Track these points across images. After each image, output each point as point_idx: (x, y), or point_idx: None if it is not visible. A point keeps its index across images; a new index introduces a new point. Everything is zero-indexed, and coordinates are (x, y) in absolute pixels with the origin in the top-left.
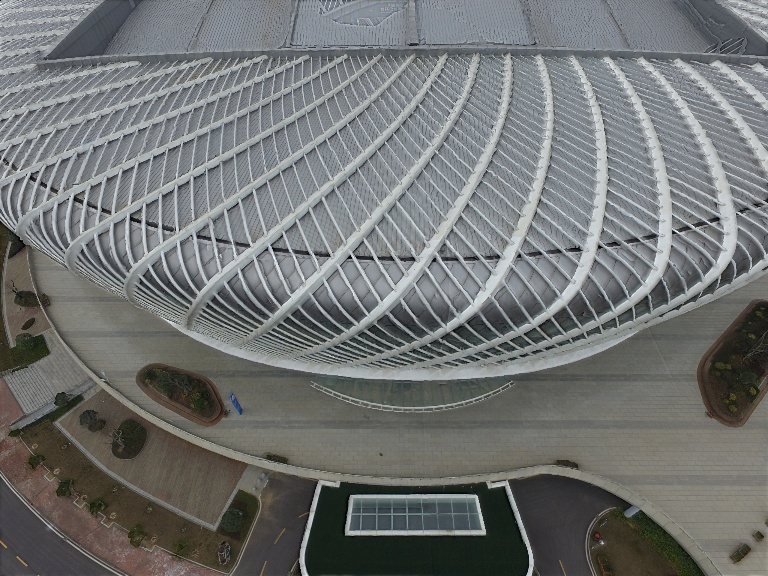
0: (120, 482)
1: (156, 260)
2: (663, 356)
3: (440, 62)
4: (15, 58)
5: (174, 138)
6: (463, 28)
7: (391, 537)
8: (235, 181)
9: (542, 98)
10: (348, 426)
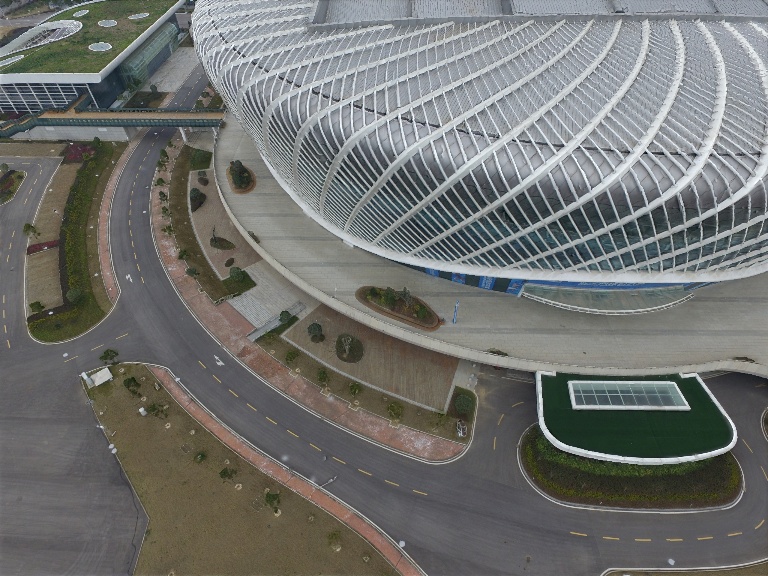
0: (353, 379)
1: (487, 157)
2: None
3: (647, 25)
4: (278, 25)
5: (462, 76)
6: (654, 0)
7: (611, 411)
8: (532, 103)
9: (744, 50)
10: (549, 332)
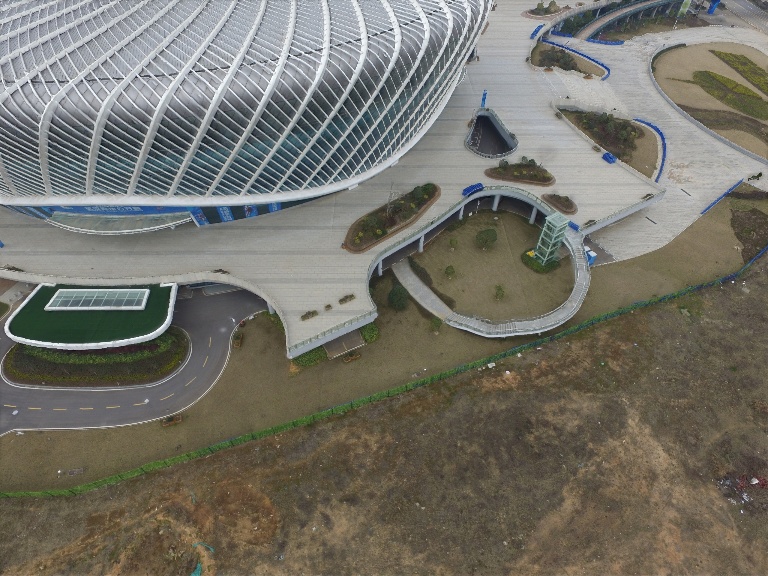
0: None
1: None
2: (334, 216)
3: None
4: None
5: None
6: None
7: (77, 311)
8: None
9: None
10: (77, 254)
